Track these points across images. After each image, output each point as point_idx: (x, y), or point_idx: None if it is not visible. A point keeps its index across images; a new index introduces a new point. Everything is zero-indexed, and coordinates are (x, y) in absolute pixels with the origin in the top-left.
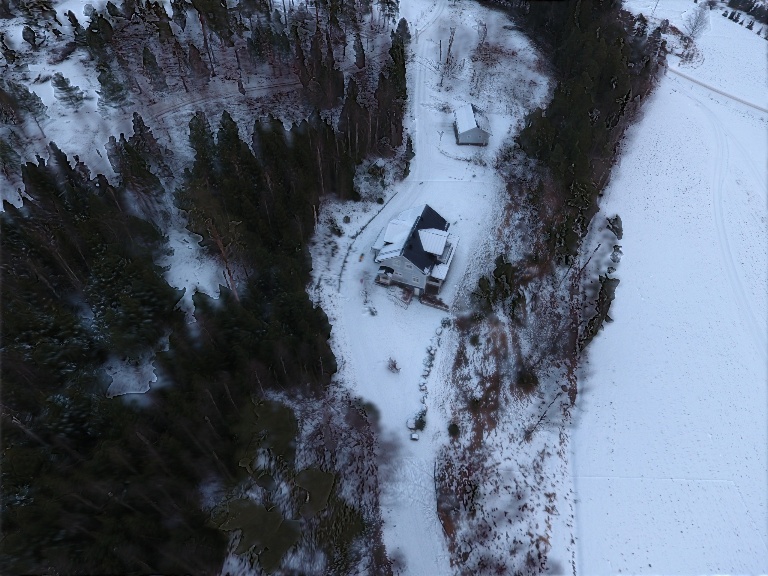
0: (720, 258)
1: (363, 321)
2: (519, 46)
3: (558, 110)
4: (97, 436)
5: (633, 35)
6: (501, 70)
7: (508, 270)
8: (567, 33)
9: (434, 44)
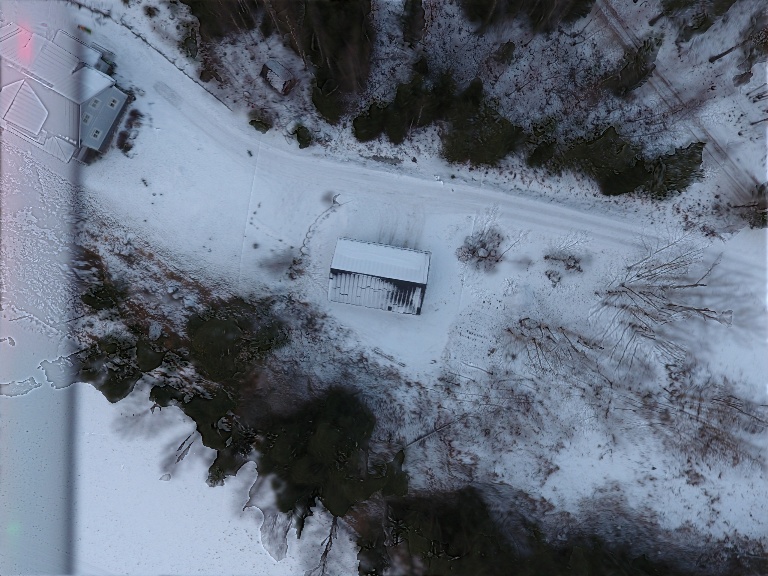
0: None
1: None
2: (733, 505)
3: None
4: None
5: None
6: (616, 418)
7: None
8: None
9: None
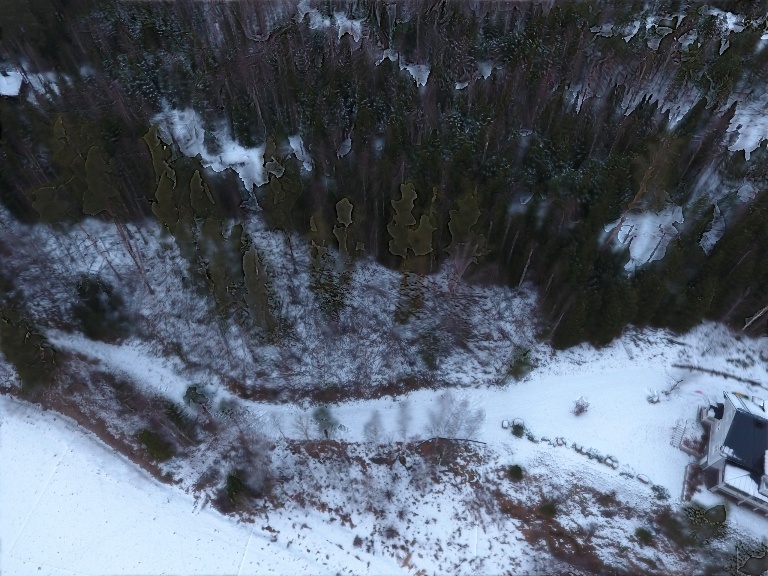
0: None
1: (637, 388)
2: None
3: None
4: None
5: None
6: None
7: (759, 560)
8: None
9: None
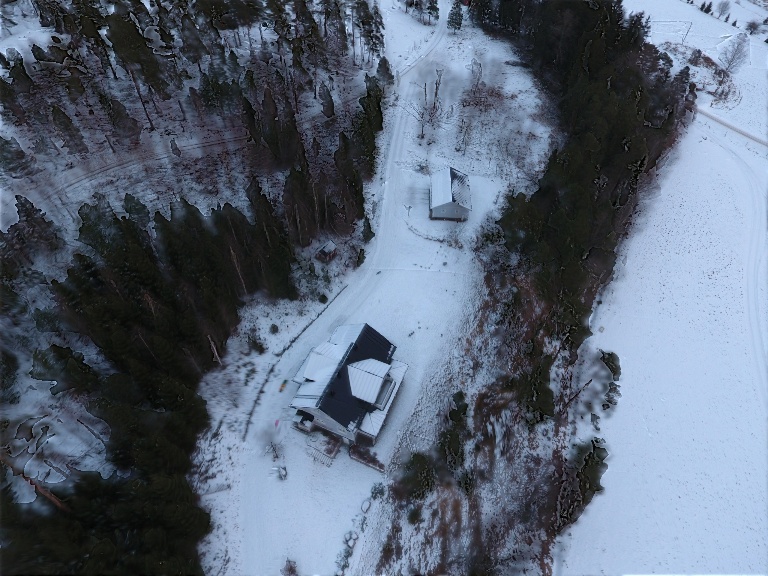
0: (753, 374)
1: (267, 489)
2: (520, 87)
3: (552, 184)
4: None
5: (657, 71)
6: (496, 118)
7: (454, 442)
8: (574, 79)
9: (419, 87)
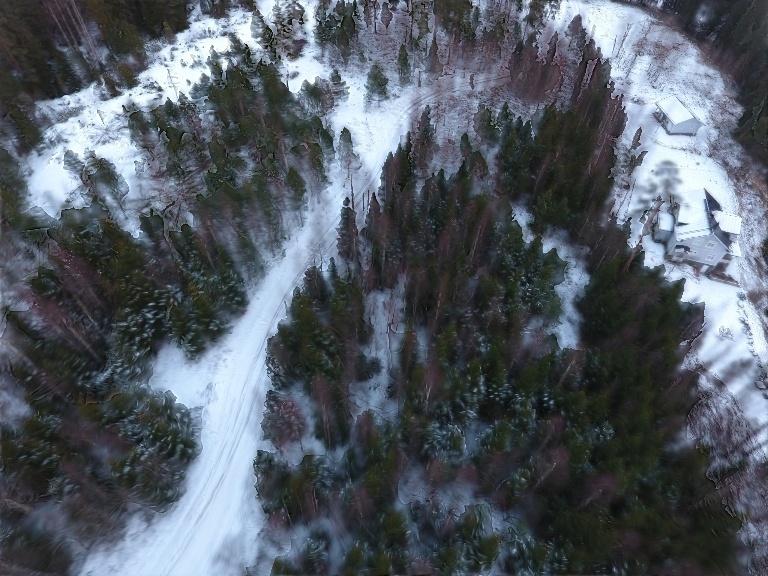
0: None
1: None
2: (676, 41)
3: None
4: (601, 385)
5: None
6: (671, 64)
7: None
8: (744, 28)
9: None
